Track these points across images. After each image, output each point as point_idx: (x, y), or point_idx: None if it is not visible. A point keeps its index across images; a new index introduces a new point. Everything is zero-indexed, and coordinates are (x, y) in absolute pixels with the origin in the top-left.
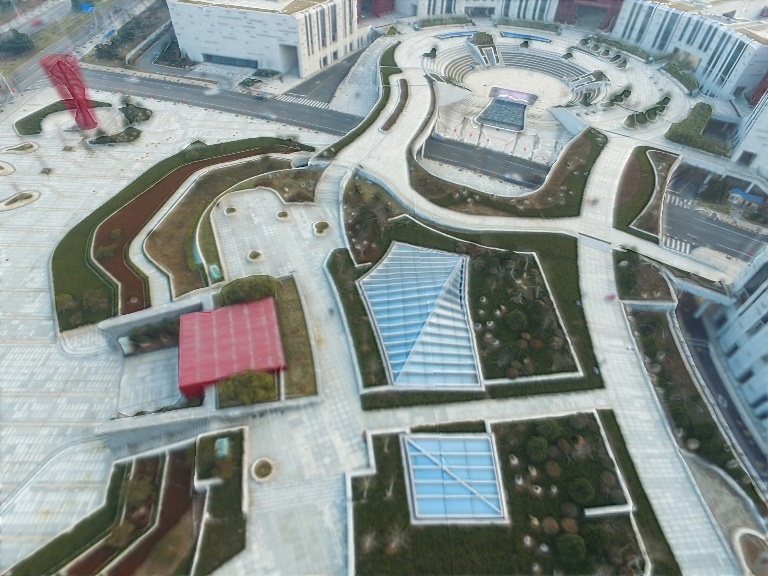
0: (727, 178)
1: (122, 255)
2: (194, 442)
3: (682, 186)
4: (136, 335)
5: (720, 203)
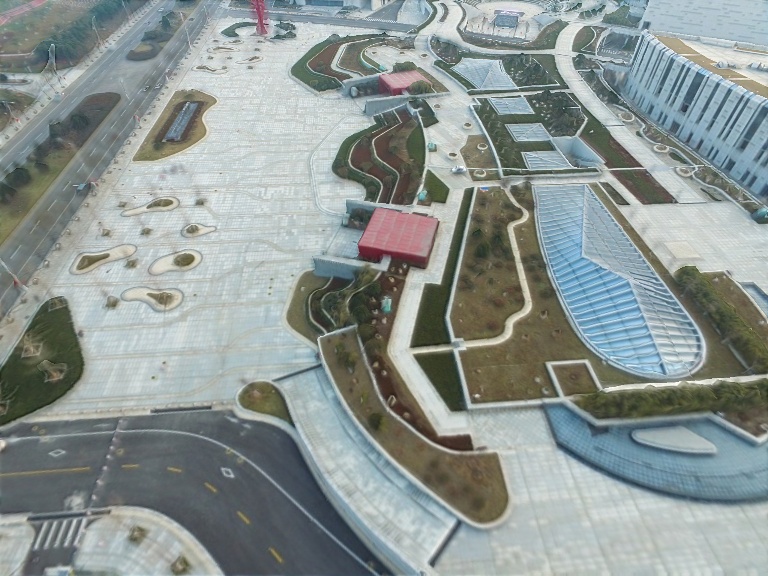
0: (636, 37)
1: (329, 70)
2: (405, 105)
3: (612, 46)
4: (358, 87)
5: (633, 51)
